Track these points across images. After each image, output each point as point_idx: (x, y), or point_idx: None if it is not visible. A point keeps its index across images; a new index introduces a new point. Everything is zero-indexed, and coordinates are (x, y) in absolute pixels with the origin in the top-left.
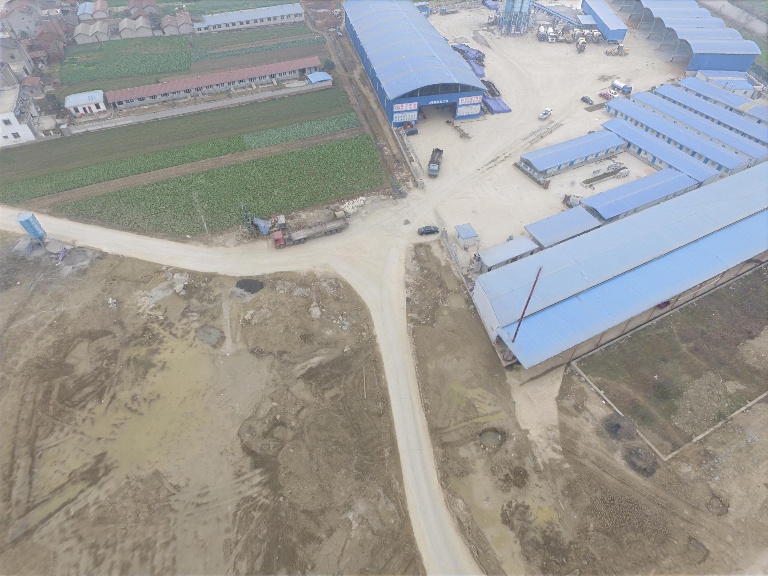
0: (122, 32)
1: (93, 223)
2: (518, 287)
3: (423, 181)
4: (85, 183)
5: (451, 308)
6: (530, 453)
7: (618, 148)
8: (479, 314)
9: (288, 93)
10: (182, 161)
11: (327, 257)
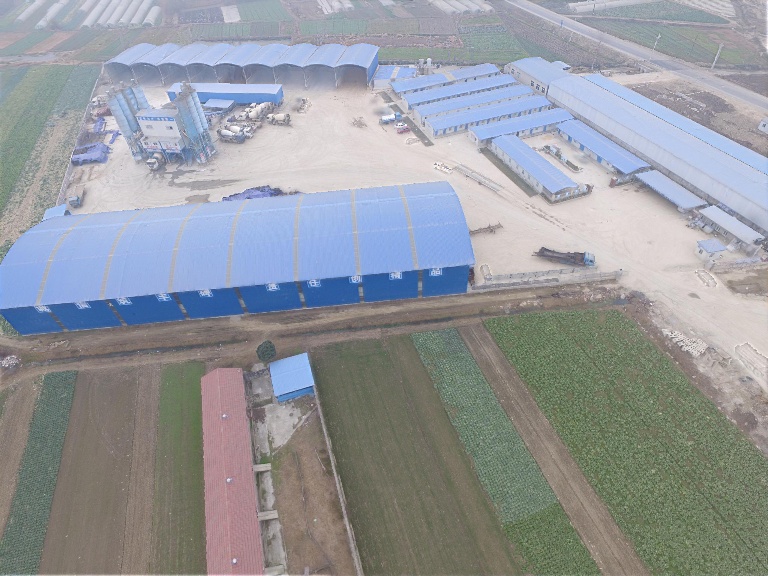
0: None
1: None
2: None
3: None
4: None
5: None
6: None
7: None
8: None
9: None
10: None
11: None
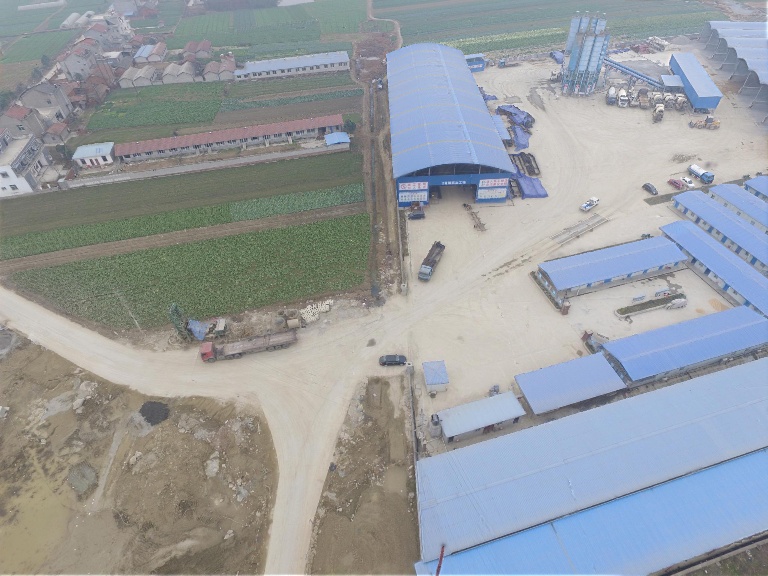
0: (164, 77)
1: (36, 300)
2: (467, 493)
3: (410, 285)
4: (52, 248)
5: (384, 491)
6: None
7: (678, 262)
8: (417, 510)
9: (299, 155)
10: (157, 230)
11: (258, 383)
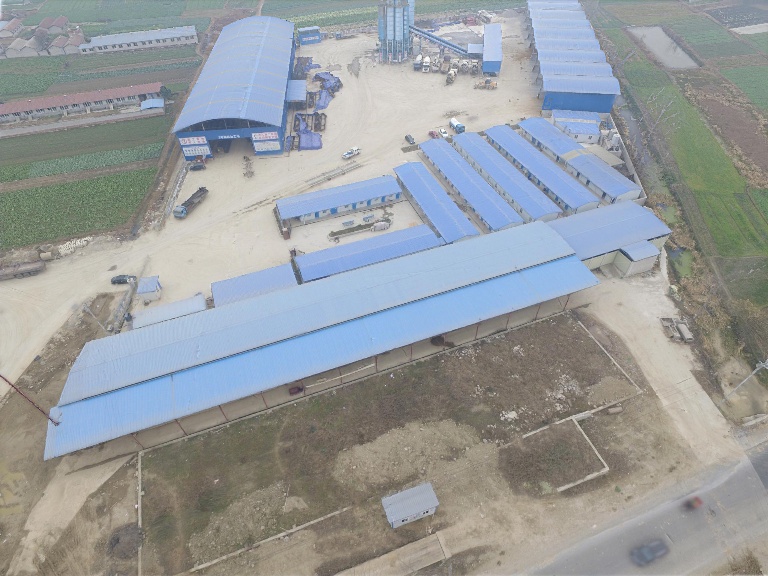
0: (7, 52)
1: None
2: (113, 359)
3: (167, 222)
4: None
5: None
6: (6, 561)
7: (401, 196)
8: None
9: (114, 119)
10: None
11: None
